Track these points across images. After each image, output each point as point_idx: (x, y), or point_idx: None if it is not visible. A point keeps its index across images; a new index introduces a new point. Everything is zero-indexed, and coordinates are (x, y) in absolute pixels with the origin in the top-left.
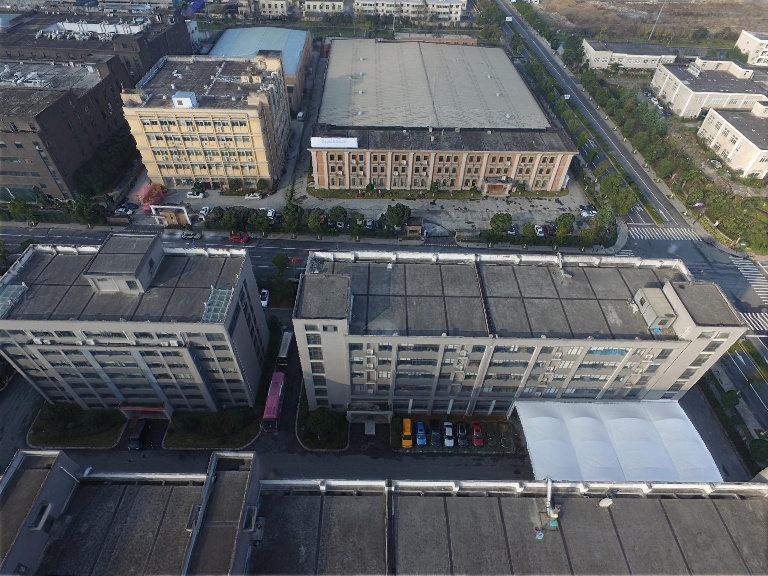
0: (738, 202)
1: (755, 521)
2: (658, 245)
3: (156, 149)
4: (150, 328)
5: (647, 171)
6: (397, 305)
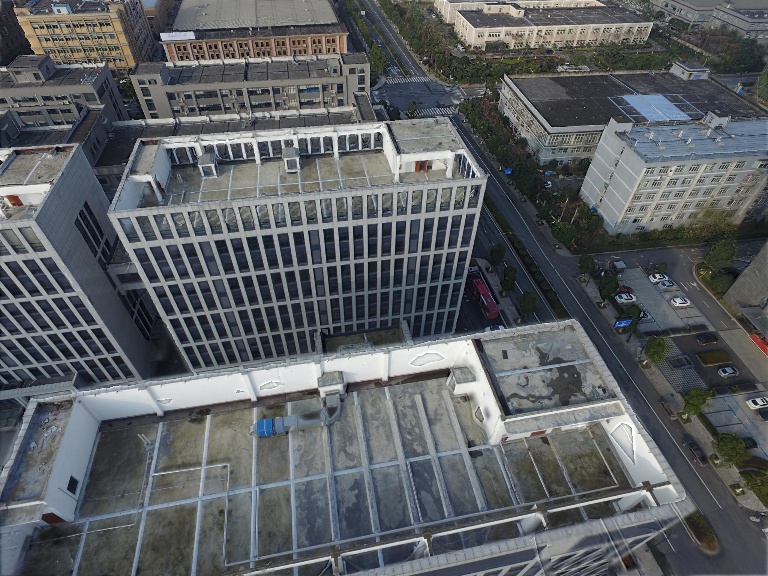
0: (448, 54)
1: (343, 118)
2: (402, 85)
3: (46, 49)
4: (50, 91)
5: (411, 52)
6: (195, 79)
